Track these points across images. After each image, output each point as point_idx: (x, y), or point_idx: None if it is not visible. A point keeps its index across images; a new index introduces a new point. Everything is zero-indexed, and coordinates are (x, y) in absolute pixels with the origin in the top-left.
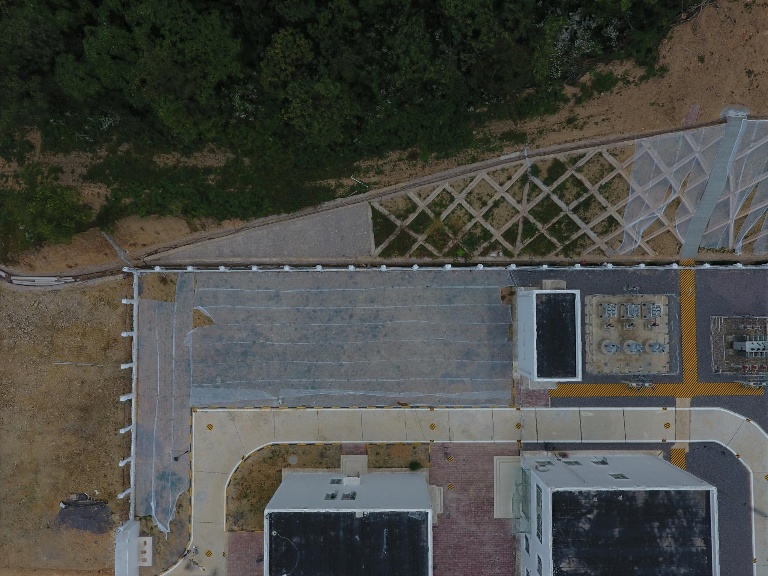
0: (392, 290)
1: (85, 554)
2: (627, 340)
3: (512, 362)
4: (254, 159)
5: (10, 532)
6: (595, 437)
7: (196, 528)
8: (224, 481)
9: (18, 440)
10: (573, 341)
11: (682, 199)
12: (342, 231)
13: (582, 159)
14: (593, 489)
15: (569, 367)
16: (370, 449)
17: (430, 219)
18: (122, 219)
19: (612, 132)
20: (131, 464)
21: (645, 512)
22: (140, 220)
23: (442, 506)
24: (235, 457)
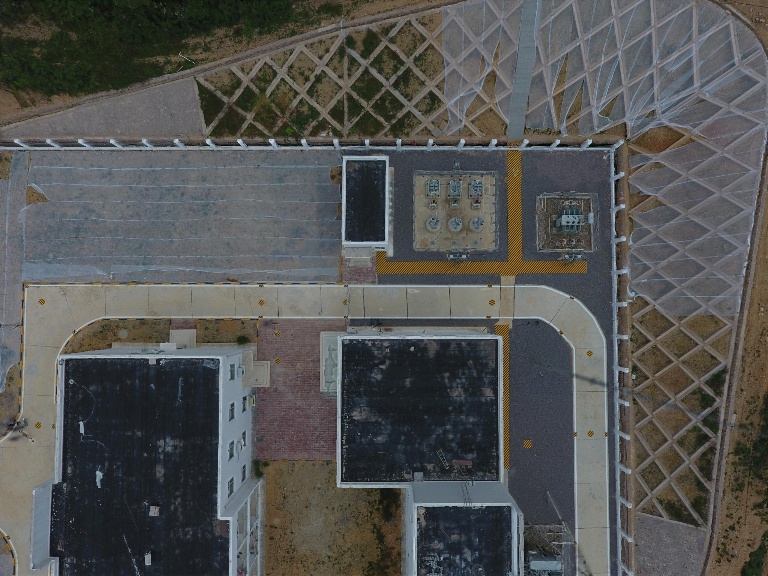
0: (224, 169)
1: None
2: (452, 217)
3: None
4: (80, 33)
5: None
6: (421, 313)
7: (26, 400)
8: (55, 355)
9: None
10: (384, 207)
11: (497, 72)
12: (171, 108)
13: (394, 29)
14: (381, 337)
15: (379, 233)
16: (199, 324)
17: (256, 95)
18: None
19: (421, 1)
20: None
21: (436, 363)
22: None
23: (269, 380)
24: (66, 331)
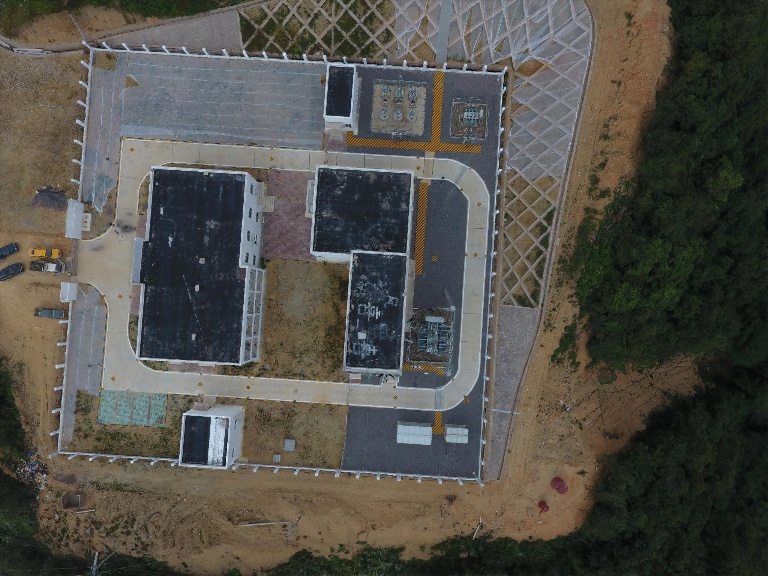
0: (252, 72)
1: (49, 223)
2: None
3: None
4: None
5: (3, 207)
6: None
7: (119, 211)
8: (138, 184)
9: (12, 151)
10: (351, 97)
11: (428, 18)
12: (222, 30)
13: None
14: (342, 167)
15: (347, 112)
16: None
17: (276, 25)
18: (83, 7)
19: None
20: (81, 167)
21: (374, 186)
22: (94, 10)
23: (273, 208)
24: (146, 169)
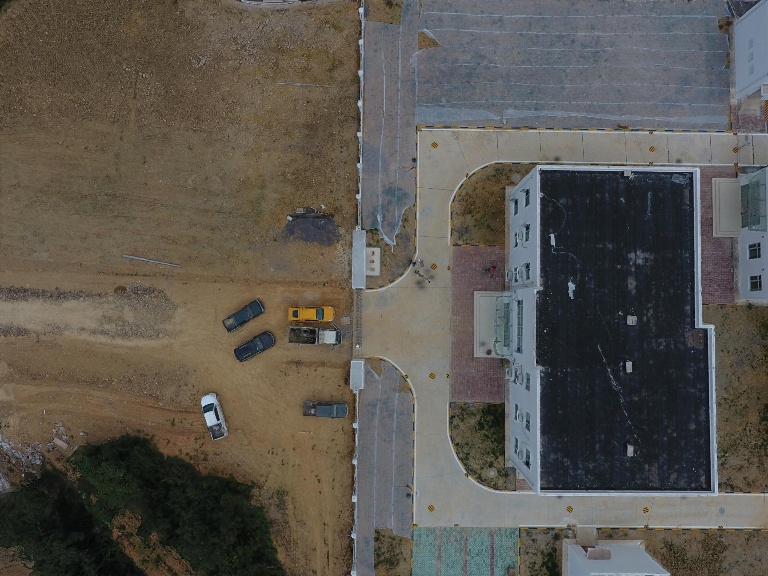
0: (612, 18)
1: (312, 266)
2: None
3: (729, 89)
4: None
5: (236, 245)
6: None
7: (421, 242)
8: (448, 197)
9: (244, 157)
10: None
11: None
12: None
13: None
14: None
15: None
16: None
17: None
18: None
19: None
20: (360, 176)
21: None
22: None
23: None
24: (459, 174)
